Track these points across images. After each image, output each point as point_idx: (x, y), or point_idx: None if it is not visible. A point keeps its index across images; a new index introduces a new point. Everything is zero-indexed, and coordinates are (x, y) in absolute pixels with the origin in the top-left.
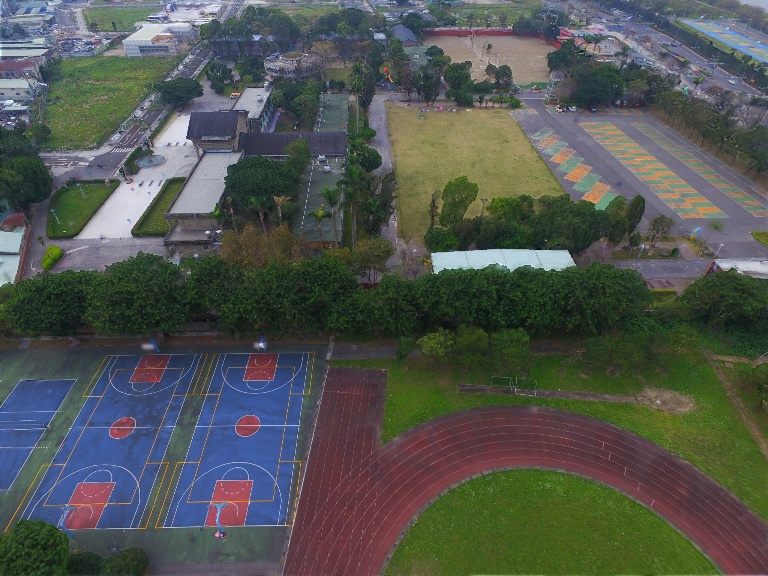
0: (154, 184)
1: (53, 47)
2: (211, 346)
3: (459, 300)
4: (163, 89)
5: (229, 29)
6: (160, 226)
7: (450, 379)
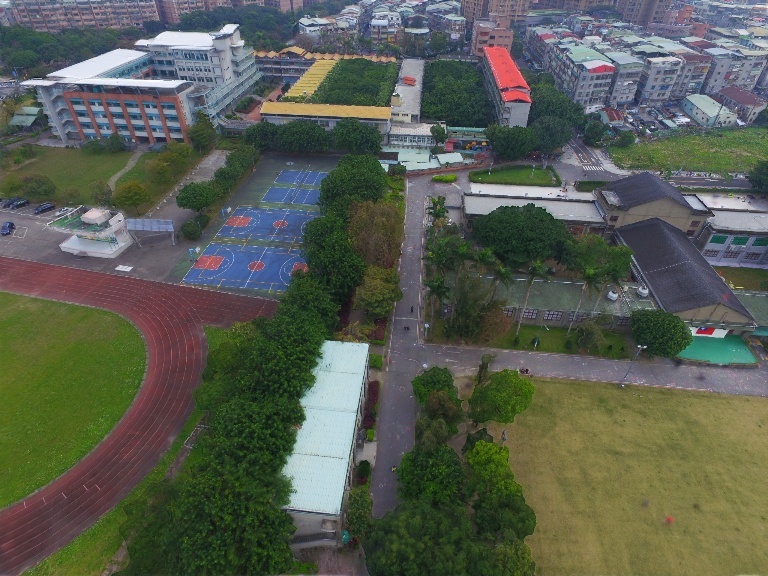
0: None
1: None
2: None
3: None
4: (761, 166)
5: None
6: None
7: None
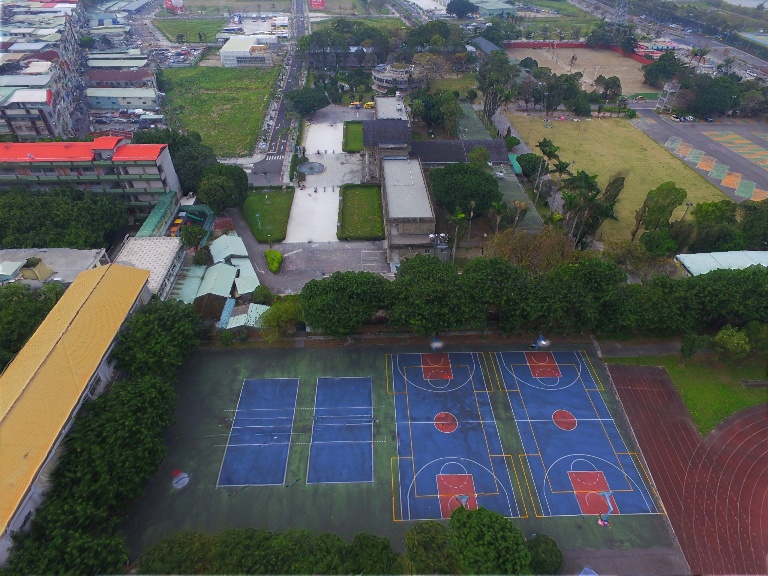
0: (328, 190)
1: (150, 58)
2: (481, 345)
3: (747, 299)
4: (296, 98)
5: (328, 41)
6: (359, 230)
7: (729, 375)
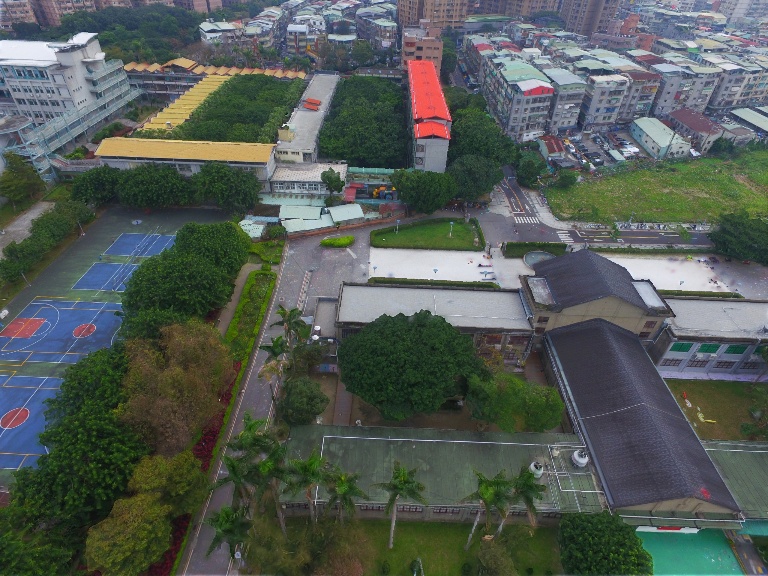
0: (486, 275)
1: None
2: None
3: None
4: (724, 223)
5: None
6: None
7: None
